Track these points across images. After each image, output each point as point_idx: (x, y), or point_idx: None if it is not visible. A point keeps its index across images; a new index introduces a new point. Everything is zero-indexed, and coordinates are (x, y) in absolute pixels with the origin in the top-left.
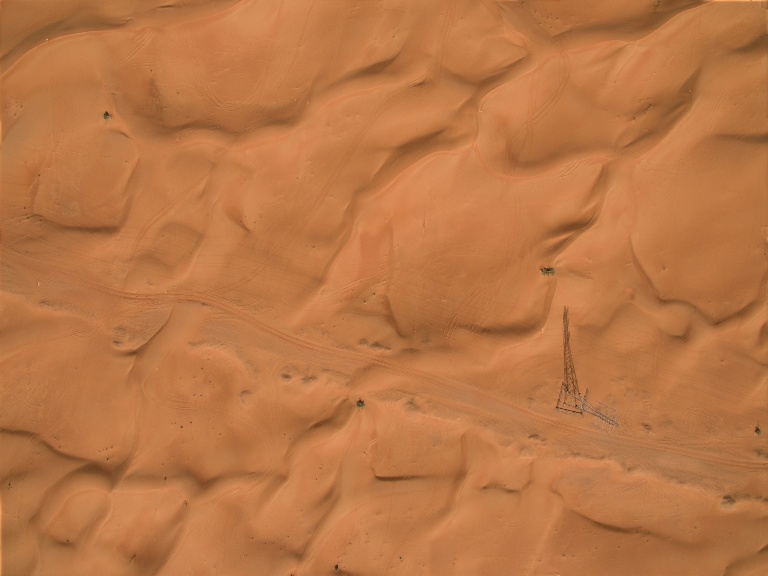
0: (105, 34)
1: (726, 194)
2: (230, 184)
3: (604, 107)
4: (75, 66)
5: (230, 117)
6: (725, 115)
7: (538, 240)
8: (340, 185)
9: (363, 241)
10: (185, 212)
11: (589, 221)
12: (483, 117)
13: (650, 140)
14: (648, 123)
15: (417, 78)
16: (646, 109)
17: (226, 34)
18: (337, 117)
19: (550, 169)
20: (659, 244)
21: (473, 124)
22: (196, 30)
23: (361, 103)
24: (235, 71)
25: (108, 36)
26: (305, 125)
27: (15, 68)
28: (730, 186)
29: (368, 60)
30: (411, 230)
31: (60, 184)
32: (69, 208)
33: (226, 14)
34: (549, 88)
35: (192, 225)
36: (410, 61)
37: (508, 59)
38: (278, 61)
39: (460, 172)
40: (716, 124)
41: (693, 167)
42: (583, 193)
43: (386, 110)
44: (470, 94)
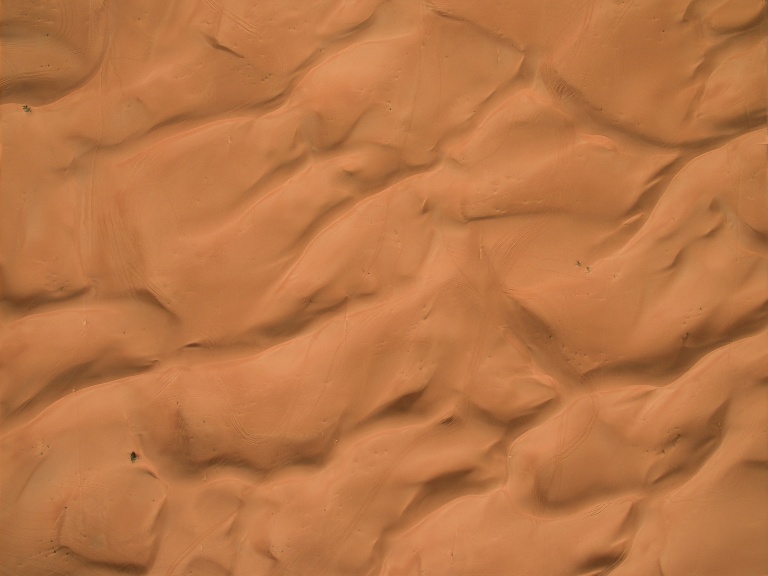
0: (132, 379)
1: (756, 522)
2: (258, 520)
3: (633, 443)
4: (102, 411)
5: (257, 450)
6: (754, 442)
7: (567, 575)
8: (368, 520)
9: (392, 575)
10: (213, 548)
11: (619, 556)
12: (512, 461)
13: (680, 477)
14: (677, 457)
15: (445, 414)
16: (675, 440)
17: (253, 374)
18: (365, 454)
19: (580, 510)
20: (688, 567)
21: (502, 469)
22: (223, 370)
23: (389, 441)
24: (262, 405)
25: (135, 380)
26: (333, 465)
27: (42, 416)
28: (760, 514)
29: (395, 393)
30: (439, 558)
31: (87, 515)
32: (96, 541)
33: (253, 358)
34: (578, 426)
35: (220, 561)
36: (438, 398)
37: (537, 399)
38: (305, 396)
39: (489, 512)
40: (745, 450)
41: (722, 496)
42: (612, 529)
43: (414, 448)
44: (499, 437)
